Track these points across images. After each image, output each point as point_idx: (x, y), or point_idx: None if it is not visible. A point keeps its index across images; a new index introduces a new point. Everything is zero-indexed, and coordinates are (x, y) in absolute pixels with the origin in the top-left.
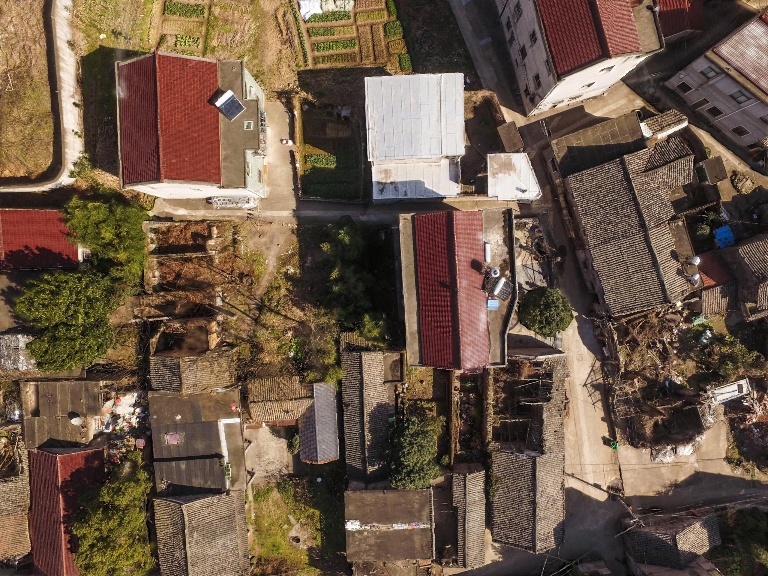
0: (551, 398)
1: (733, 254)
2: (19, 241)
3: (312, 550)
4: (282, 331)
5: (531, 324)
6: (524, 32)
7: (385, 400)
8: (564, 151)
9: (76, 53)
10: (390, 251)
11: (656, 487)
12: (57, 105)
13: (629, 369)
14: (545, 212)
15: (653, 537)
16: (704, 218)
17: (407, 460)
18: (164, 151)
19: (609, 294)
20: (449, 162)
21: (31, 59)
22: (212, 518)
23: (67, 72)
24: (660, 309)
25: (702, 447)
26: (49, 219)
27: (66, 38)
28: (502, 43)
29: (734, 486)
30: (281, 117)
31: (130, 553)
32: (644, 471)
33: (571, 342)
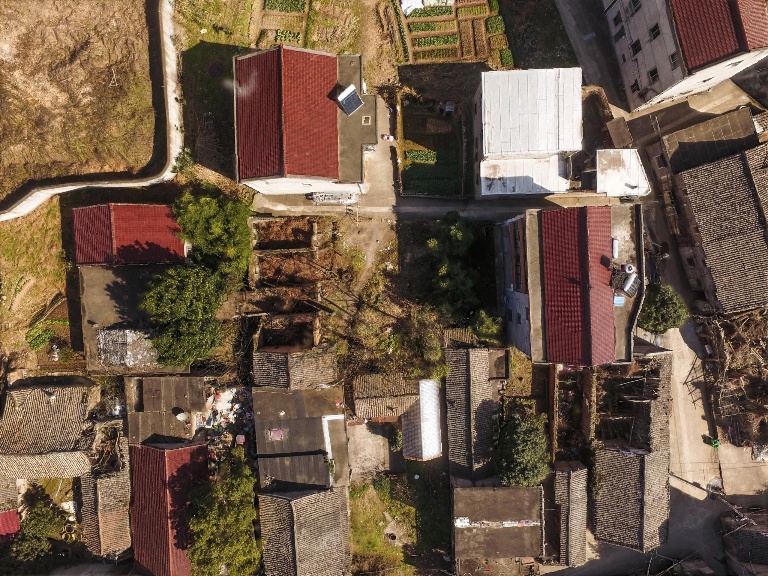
0: (658, 396)
1: None
2: (130, 236)
3: (407, 547)
4: (380, 327)
5: (645, 321)
6: (641, 27)
7: (489, 397)
8: (675, 147)
9: (177, 48)
10: (490, 247)
11: (757, 486)
12: (158, 100)
13: (731, 367)
14: (647, 209)
15: (759, 536)
16: None
17: (521, 457)
18: (287, 146)
19: (722, 291)
20: (558, 158)
21: (134, 54)
22: (318, 514)
23: (170, 67)
24: None
25: None
26: (158, 214)
27: (169, 33)
28: (606, 38)
29: None
30: (382, 112)
31: (247, 549)
32: (745, 470)
33: (672, 340)
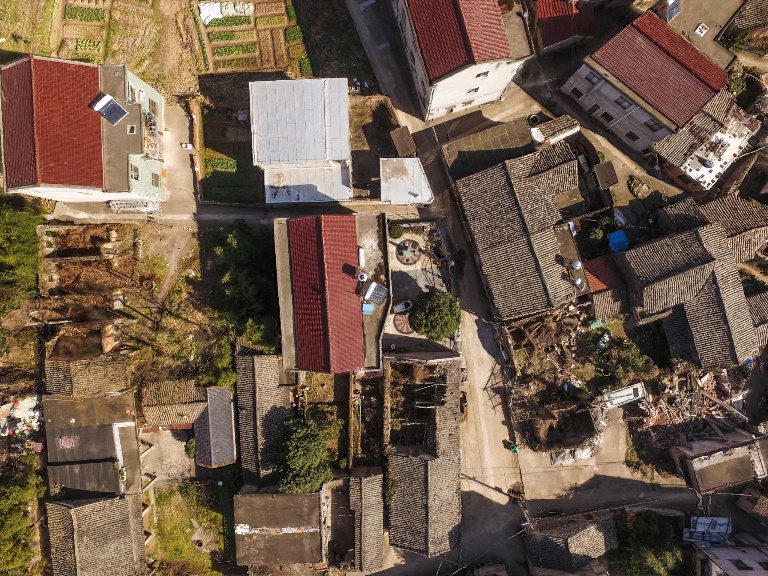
0: (445, 402)
1: (622, 258)
2: None
3: (215, 554)
4: (183, 335)
5: (418, 328)
6: (410, 38)
7: (280, 404)
8: (455, 156)
9: None
10: None
11: (556, 490)
12: None
13: (528, 373)
14: (444, 216)
15: (547, 540)
16: (598, 222)
17: (292, 464)
18: (41, 155)
19: (498, 298)
20: (341, 166)
21: None
22: (104, 522)
23: None
24: (558, 313)
25: (602, 450)
26: None
27: None
28: (400, 48)
29: (634, 489)
30: (181, 121)
31: (10, 557)
32: (544, 474)
33: (471, 346)
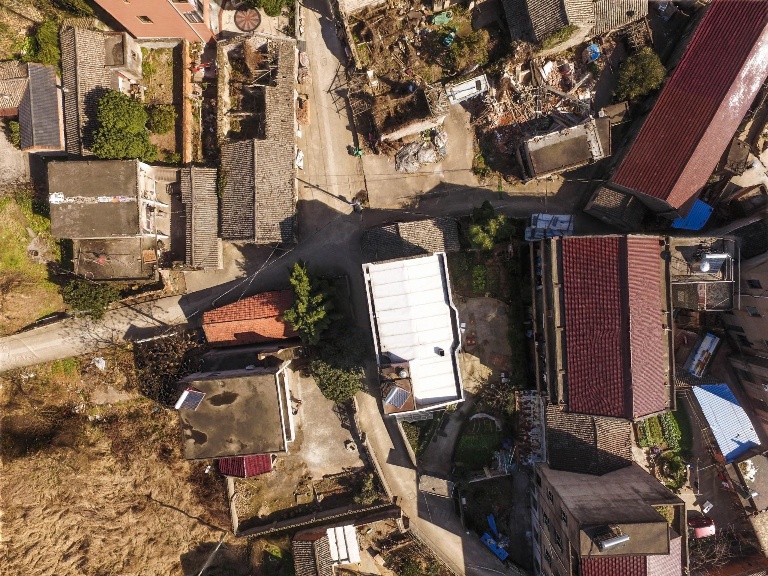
0: (276, 84)
1: None
2: None
3: (52, 265)
4: (17, 30)
5: None
6: None
7: (107, 85)
8: None
9: None
10: None
11: None
12: None
13: None
14: None
15: (382, 232)
16: None
17: (102, 118)
18: None
19: None
20: None
21: None
22: None
23: None
24: (402, 7)
25: (448, 157)
26: None
27: None
28: None
29: (481, 198)
30: None
31: None
32: (389, 181)
33: (315, 46)
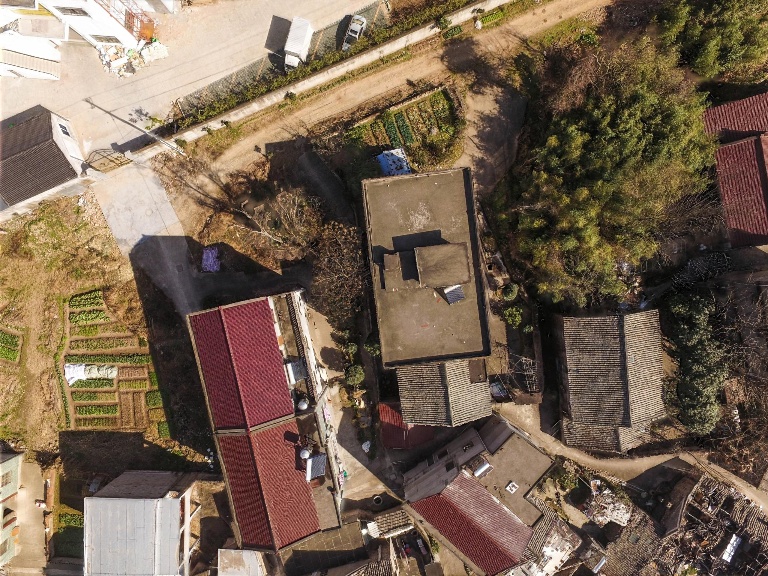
0: None
1: None
2: None
3: None
4: None
5: None
6: None
7: None
8: (289, 554)
9: None
10: None
11: None
12: None
13: None
14: None
15: None
16: None
17: None
18: None
19: None
20: None
21: None
22: None
23: None
24: None
25: None
26: None
27: None
28: None
29: None
30: (37, 478)
31: None
32: None
33: None
